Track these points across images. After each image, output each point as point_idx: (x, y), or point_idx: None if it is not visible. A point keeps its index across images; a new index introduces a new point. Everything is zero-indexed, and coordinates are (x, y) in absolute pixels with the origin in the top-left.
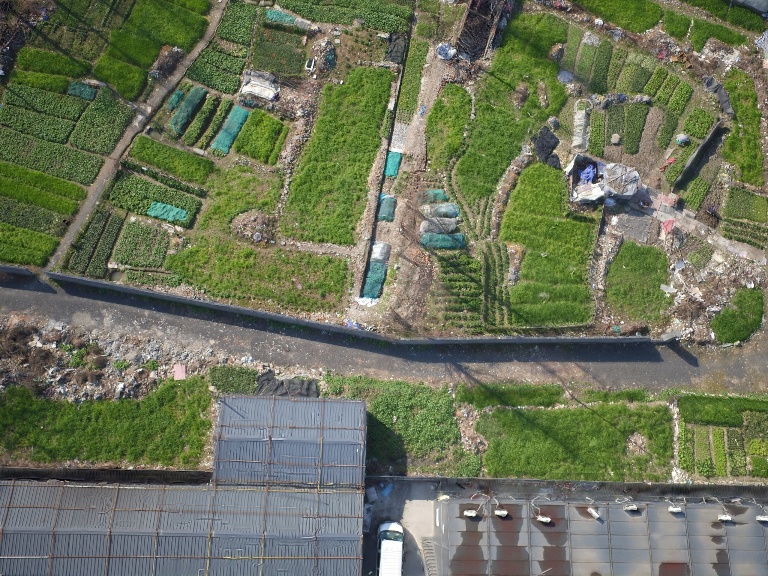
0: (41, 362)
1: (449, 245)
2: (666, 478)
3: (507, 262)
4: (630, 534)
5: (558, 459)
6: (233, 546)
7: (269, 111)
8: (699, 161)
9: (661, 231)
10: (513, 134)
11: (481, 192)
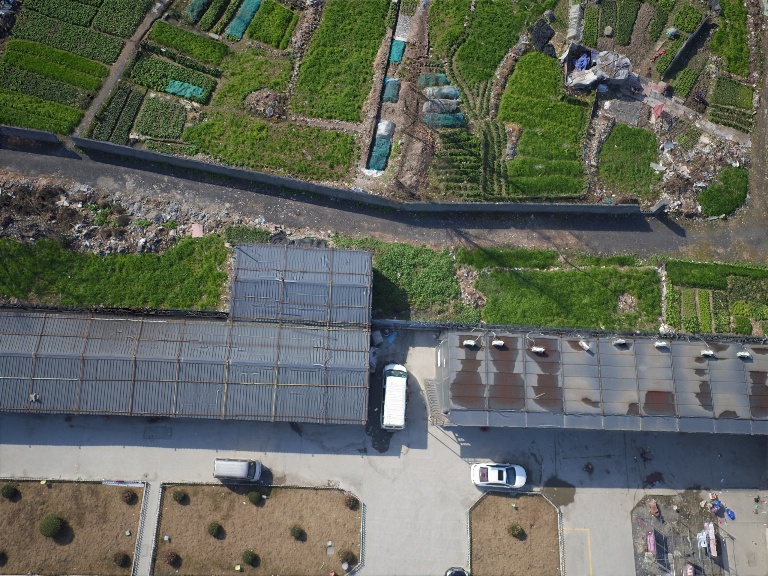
0: (68, 219)
1: (450, 123)
2: (654, 333)
3: (505, 139)
4: (618, 365)
5: (552, 313)
6: (249, 370)
7: (280, 1)
8: (688, 53)
9: (651, 116)
10: (511, 24)
11: (480, 76)
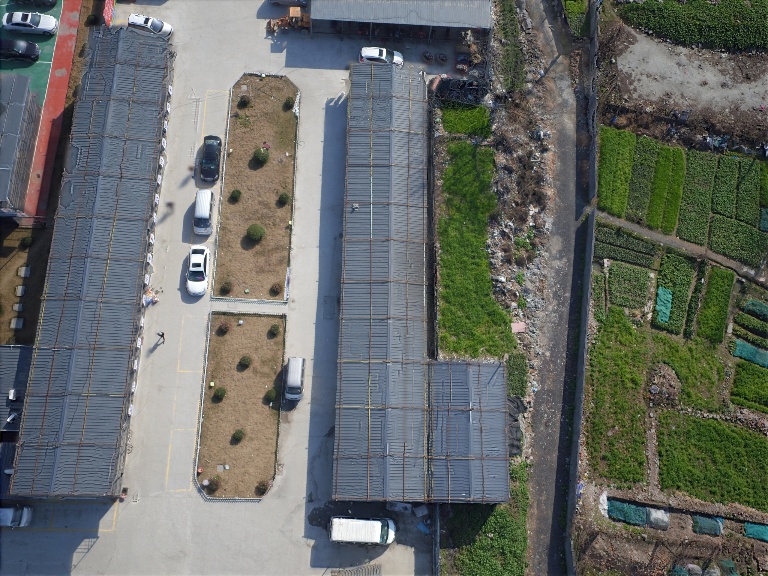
0: (517, 216)
1: None
2: None
3: None
4: None
5: None
6: (381, 381)
7: None
8: None
9: None
10: None
11: None
